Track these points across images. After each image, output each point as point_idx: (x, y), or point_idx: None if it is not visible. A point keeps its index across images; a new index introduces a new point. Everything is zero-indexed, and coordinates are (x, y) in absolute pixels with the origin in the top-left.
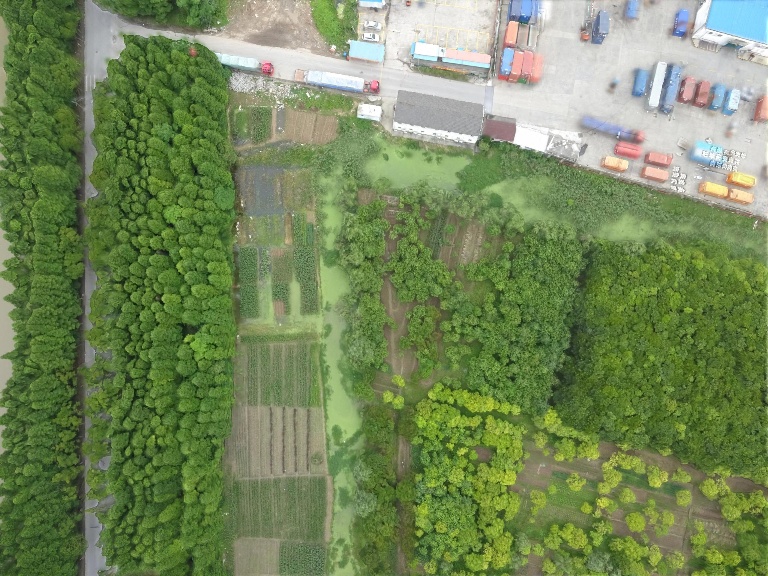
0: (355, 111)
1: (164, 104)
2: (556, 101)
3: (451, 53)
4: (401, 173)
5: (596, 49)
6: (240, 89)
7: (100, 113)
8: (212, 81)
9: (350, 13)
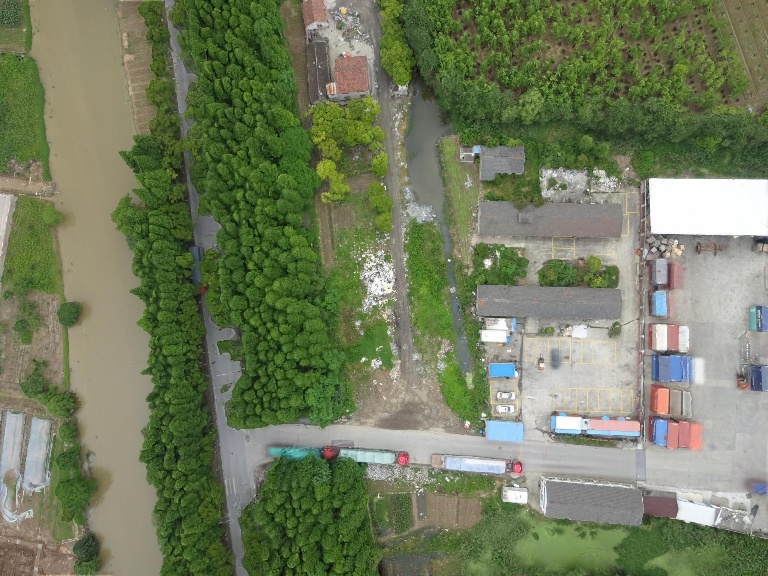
0: (498, 491)
1: (313, 542)
2: (717, 460)
3: (595, 424)
4: (554, 552)
5: (756, 396)
6: (377, 478)
7: (250, 549)
8: (354, 499)
9: (481, 385)
